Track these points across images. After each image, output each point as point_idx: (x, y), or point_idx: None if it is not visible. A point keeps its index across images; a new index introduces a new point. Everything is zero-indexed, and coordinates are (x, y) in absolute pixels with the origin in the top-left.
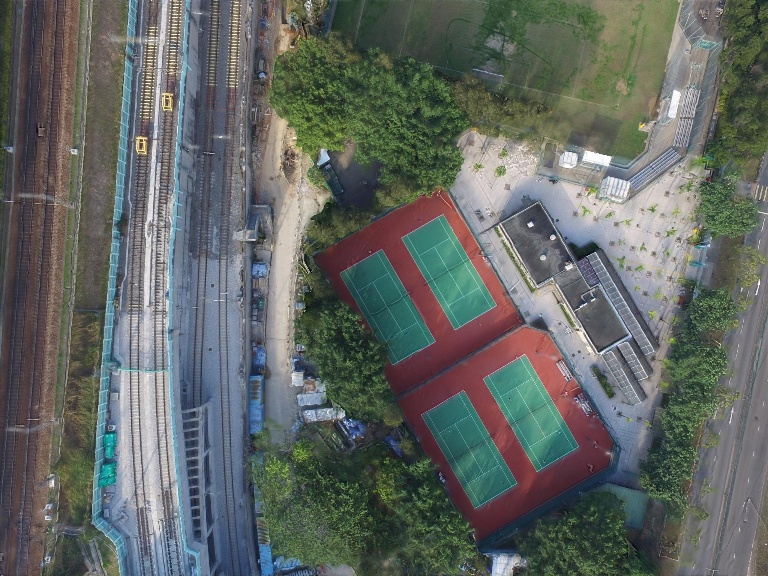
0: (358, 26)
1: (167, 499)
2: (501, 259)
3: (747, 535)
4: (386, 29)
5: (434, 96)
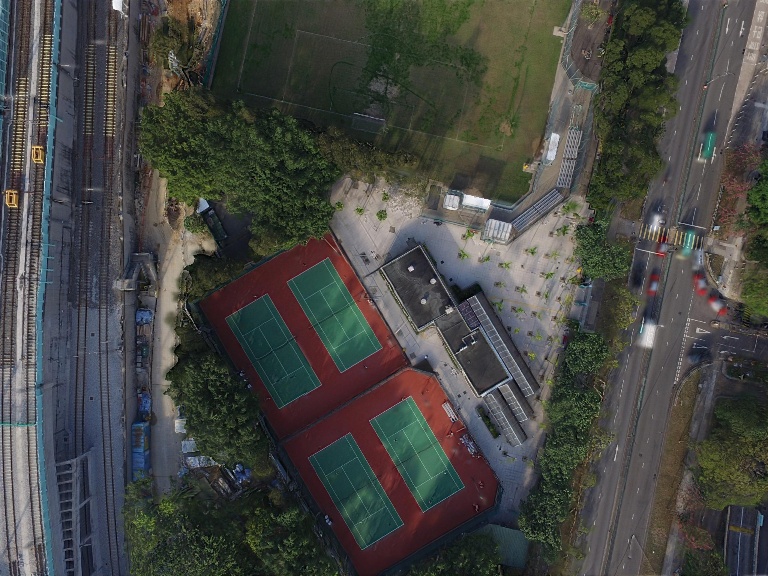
0: (241, 70)
1: (40, 552)
2: (386, 302)
3: (631, 571)
4: (269, 73)
5: (299, 148)
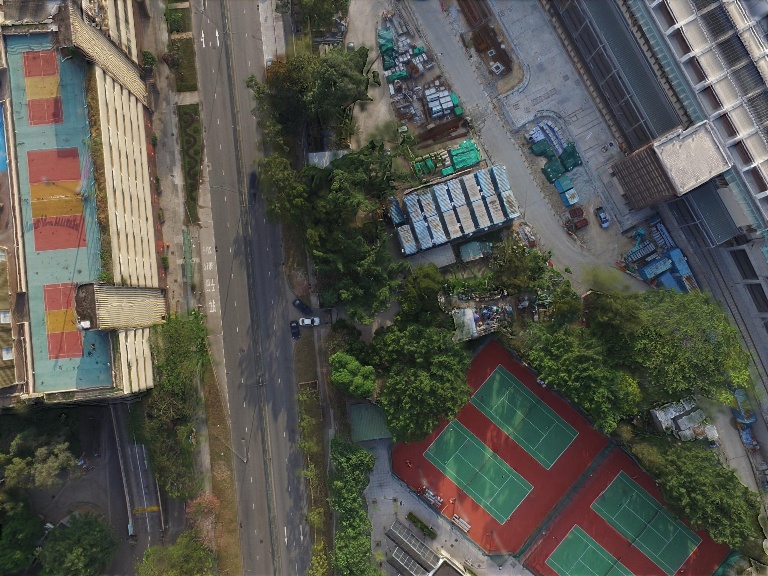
0: None
1: None
2: None
3: (238, 428)
4: None
5: None
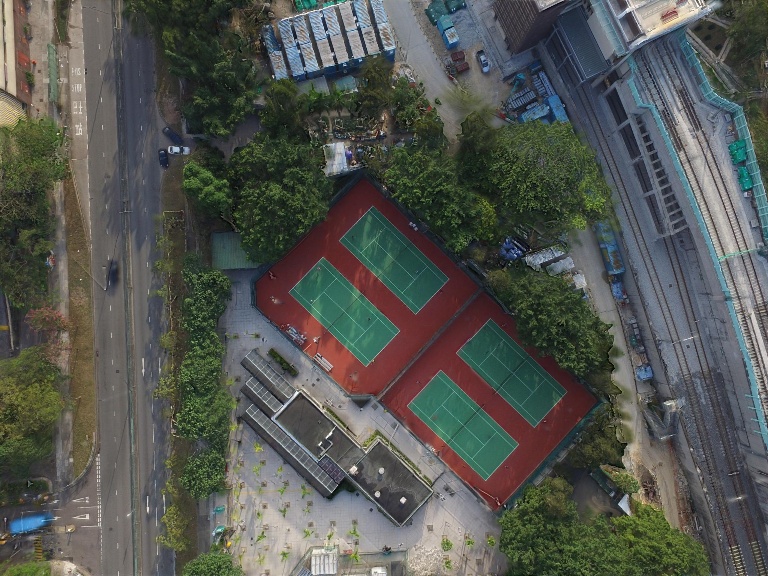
0: None
1: (678, 145)
2: (416, 453)
3: (99, 254)
4: None
5: None
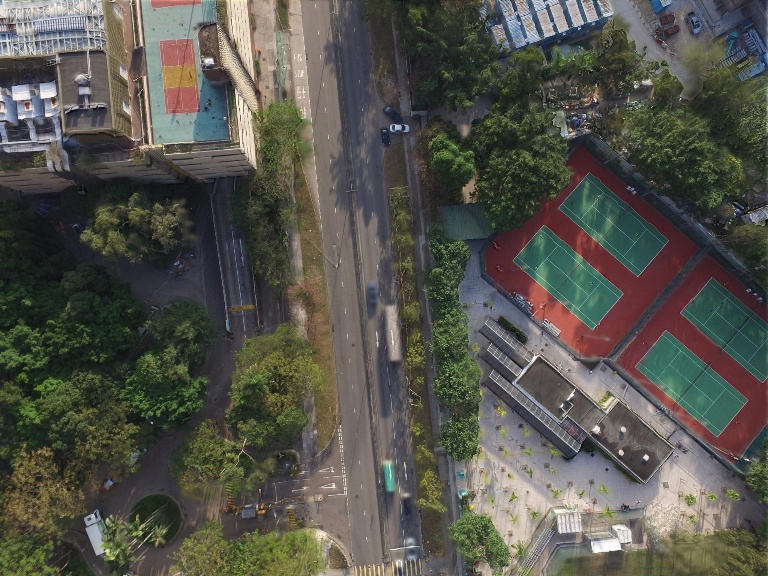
0: None
1: None
2: (647, 413)
3: (329, 233)
4: None
5: None
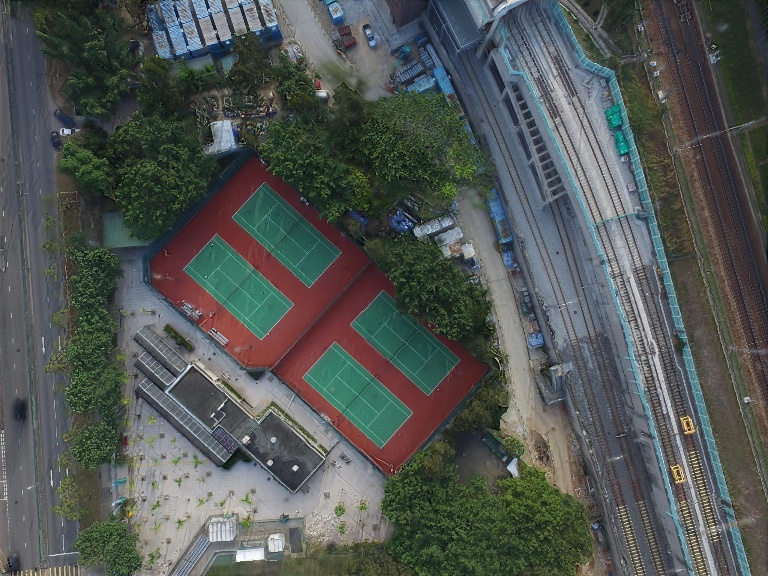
0: None
1: (554, 111)
2: (312, 423)
3: None
4: None
5: (433, 568)
